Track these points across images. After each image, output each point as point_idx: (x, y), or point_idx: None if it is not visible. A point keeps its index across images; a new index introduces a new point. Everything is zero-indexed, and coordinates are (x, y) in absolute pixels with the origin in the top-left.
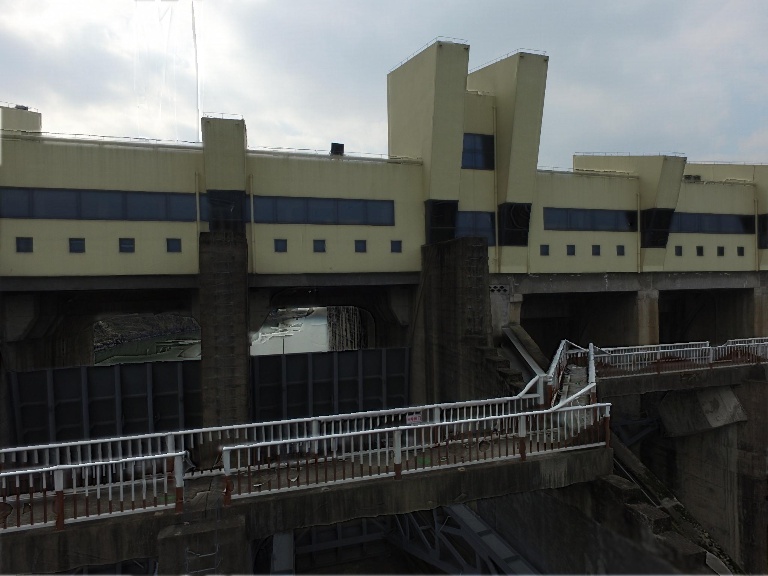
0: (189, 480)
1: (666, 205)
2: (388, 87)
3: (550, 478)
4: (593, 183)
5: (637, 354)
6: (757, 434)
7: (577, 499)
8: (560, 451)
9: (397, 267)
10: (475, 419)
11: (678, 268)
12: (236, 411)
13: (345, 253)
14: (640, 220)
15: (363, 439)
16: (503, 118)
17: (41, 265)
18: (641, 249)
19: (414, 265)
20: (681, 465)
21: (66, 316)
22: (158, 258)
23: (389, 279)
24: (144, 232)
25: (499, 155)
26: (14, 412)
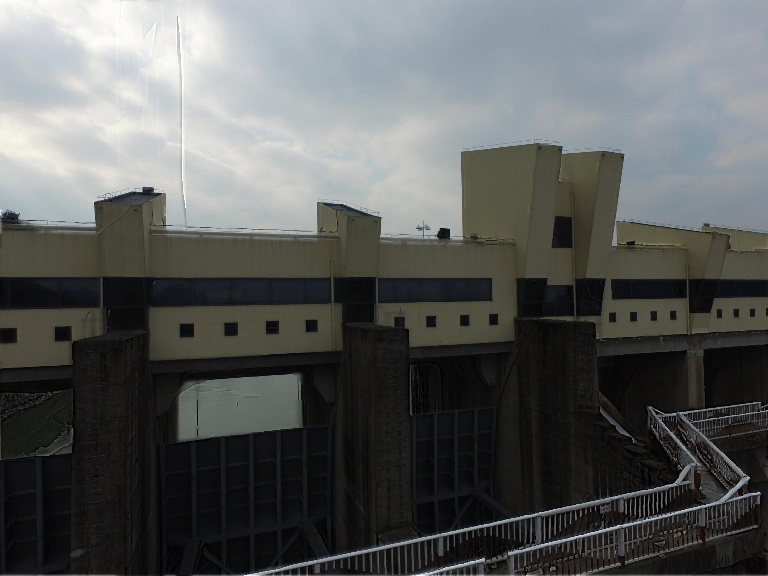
0: None
1: (712, 276)
2: (463, 163)
3: (722, 559)
4: (650, 256)
5: (713, 420)
6: None
7: (729, 570)
8: (726, 535)
9: (494, 338)
10: (671, 514)
11: (719, 329)
12: (402, 488)
13: (452, 327)
14: (689, 288)
15: (598, 538)
16: (581, 203)
17: (200, 348)
18: (690, 314)
19: (508, 336)
20: None
21: (186, 383)
22: (298, 338)
23: (487, 349)
24: (287, 315)
25: (577, 235)
26: (160, 482)
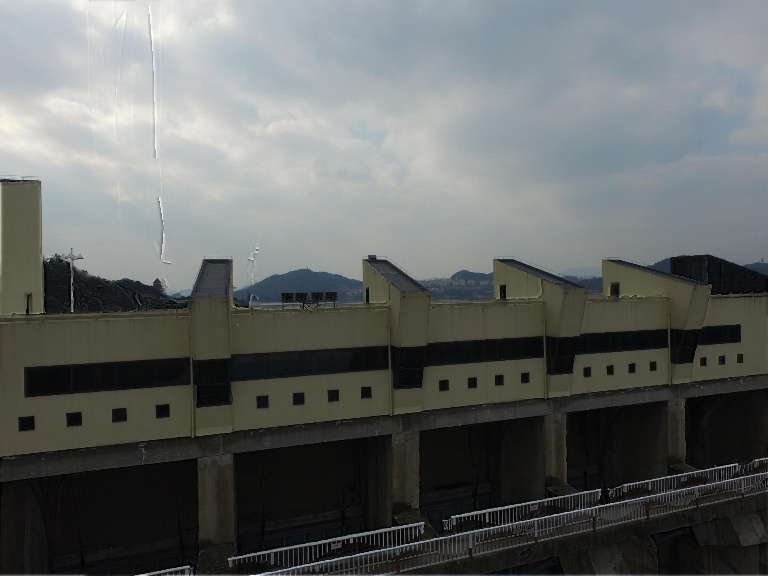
0: None
1: (213, 355)
2: None
3: None
4: (114, 328)
5: None
6: None
7: None
8: None
9: None
10: None
11: (262, 424)
12: None
13: None
14: (193, 370)
15: None
16: None
17: None
18: (195, 407)
19: None
20: None
21: None
22: None
23: None
24: None
25: None
26: None
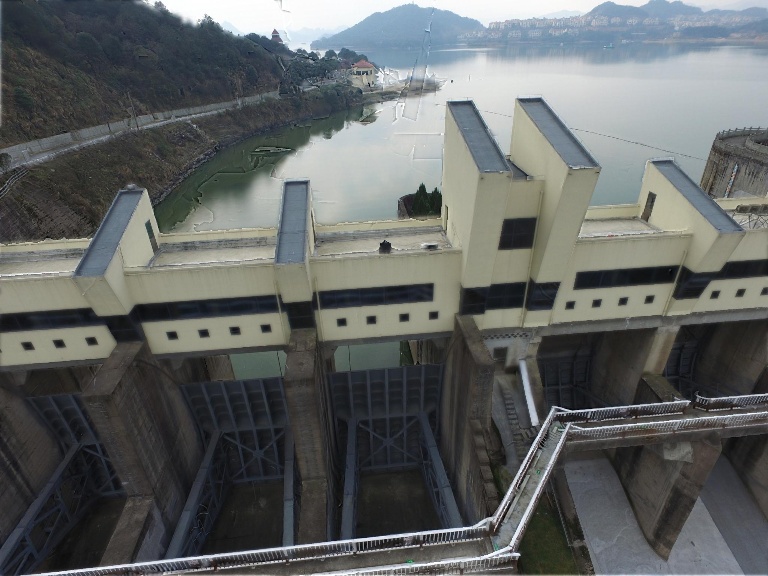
0: (295, 562)
1: (709, 269)
2: (446, 117)
3: None
4: (637, 246)
5: (608, 428)
6: (696, 473)
7: None
8: None
9: (433, 329)
10: (435, 564)
11: (709, 309)
12: (317, 461)
13: (391, 323)
14: (680, 274)
15: (374, 572)
16: (547, 209)
17: (185, 346)
18: (672, 298)
19: (448, 327)
20: (644, 456)
21: None
22: (257, 337)
23: (427, 336)
24: (245, 322)
25: (538, 238)
26: (188, 403)
